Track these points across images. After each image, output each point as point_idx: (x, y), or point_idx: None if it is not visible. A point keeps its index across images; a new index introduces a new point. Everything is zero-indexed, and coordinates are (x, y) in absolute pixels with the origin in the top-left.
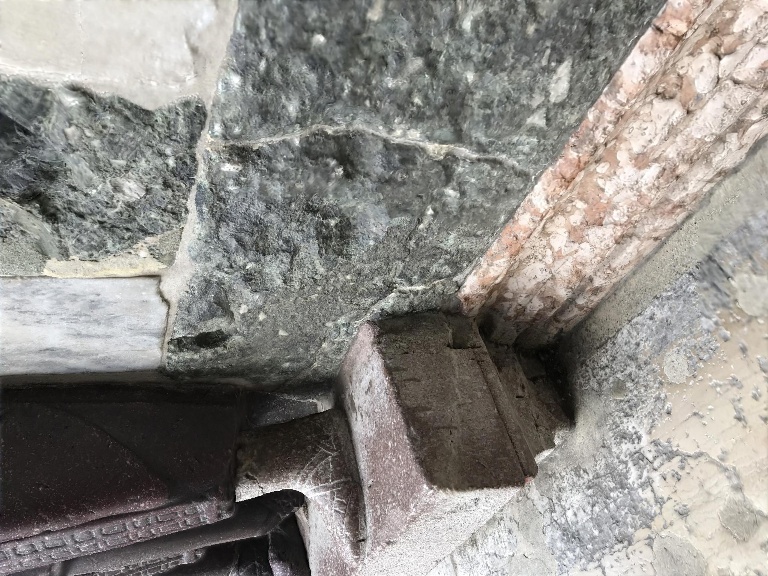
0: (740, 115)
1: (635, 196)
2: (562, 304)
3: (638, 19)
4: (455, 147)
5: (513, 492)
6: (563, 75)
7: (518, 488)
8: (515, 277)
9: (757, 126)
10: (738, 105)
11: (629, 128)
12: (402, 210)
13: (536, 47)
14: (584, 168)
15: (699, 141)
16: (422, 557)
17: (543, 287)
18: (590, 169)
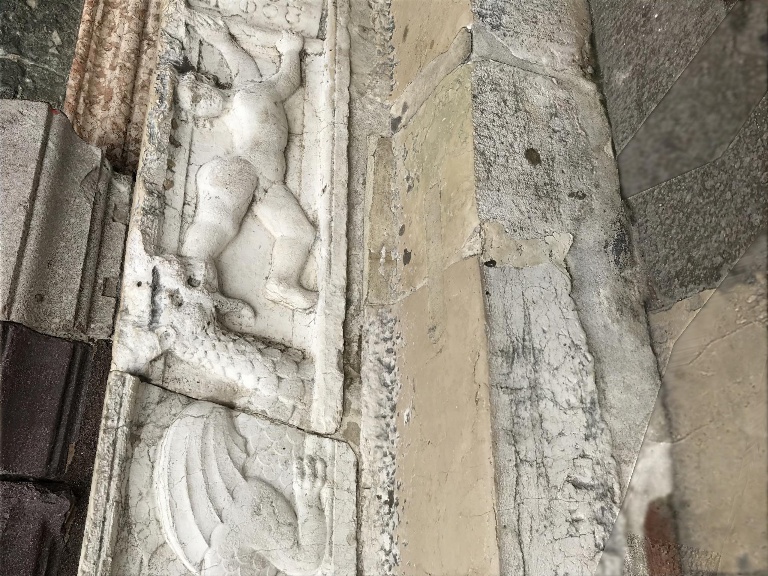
0: (138, 46)
1: (116, 79)
2: (125, 156)
3: (75, 21)
4: (22, 59)
5: (45, 110)
6: (56, 36)
7: (46, 105)
8: (90, 143)
9: (150, 51)
10: (130, 39)
11: (103, 63)
12: (4, 83)
13: (40, 26)
14: (87, 72)
15: (125, 53)
16: (7, 191)
17: (104, 140)
18: (97, 82)
